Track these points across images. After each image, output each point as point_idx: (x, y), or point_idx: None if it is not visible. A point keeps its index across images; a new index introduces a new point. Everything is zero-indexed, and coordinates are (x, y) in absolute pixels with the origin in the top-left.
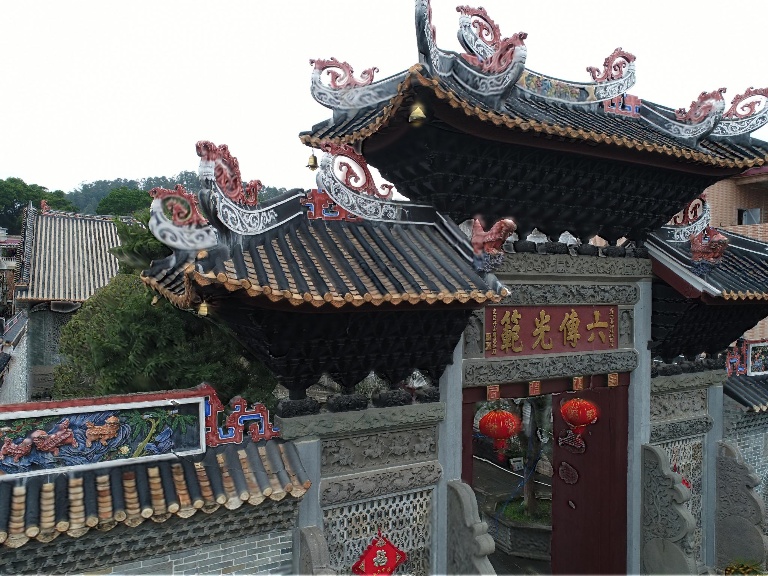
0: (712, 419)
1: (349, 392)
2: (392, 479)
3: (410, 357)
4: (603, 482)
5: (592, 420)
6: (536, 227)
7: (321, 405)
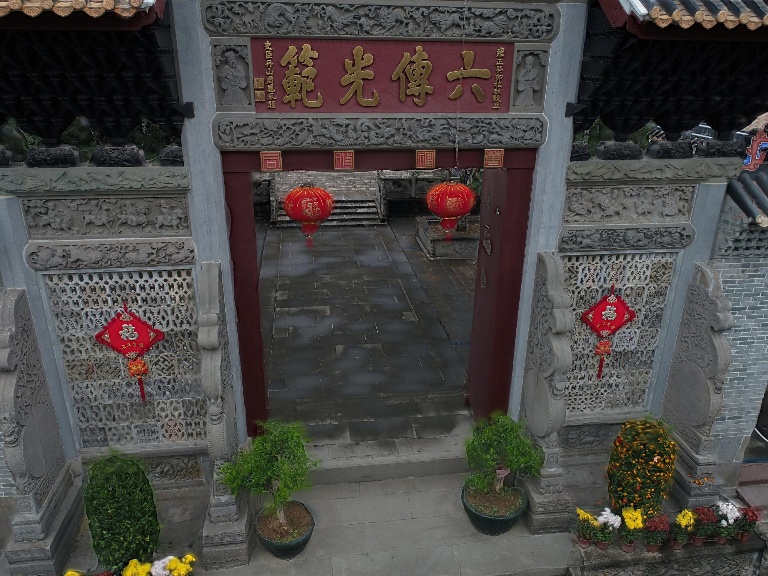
0: (694, 230)
1: (48, 144)
2: (123, 251)
3: (108, 103)
4: (494, 293)
5: (458, 212)
6: None
7: (402, 181)
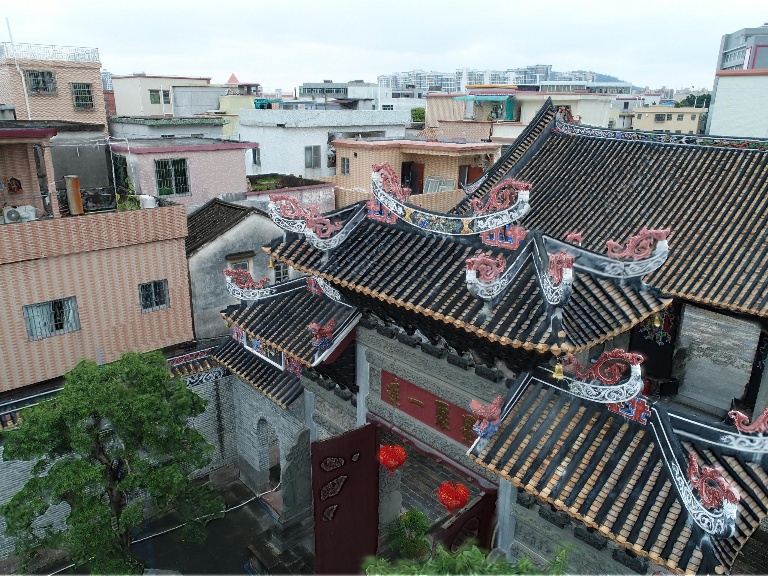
0: None
1: None
2: None
3: None
4: (369, 493)
5: None
6: (437, 338)
7: None
